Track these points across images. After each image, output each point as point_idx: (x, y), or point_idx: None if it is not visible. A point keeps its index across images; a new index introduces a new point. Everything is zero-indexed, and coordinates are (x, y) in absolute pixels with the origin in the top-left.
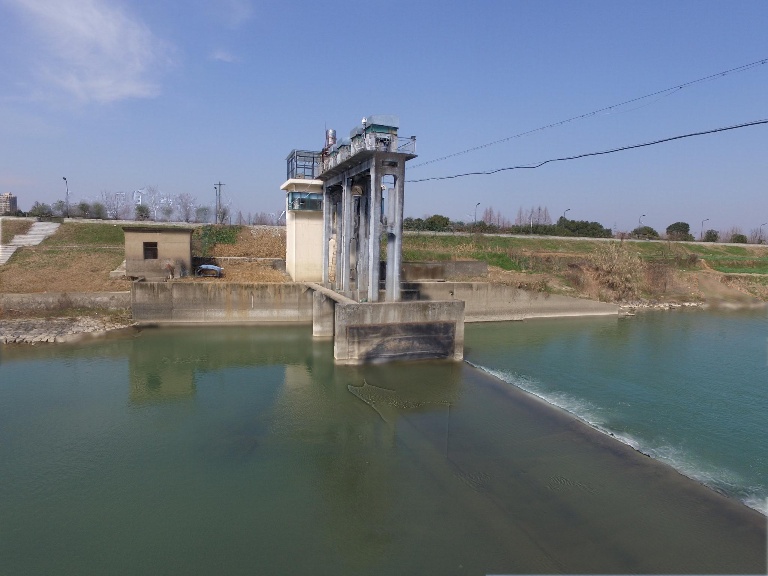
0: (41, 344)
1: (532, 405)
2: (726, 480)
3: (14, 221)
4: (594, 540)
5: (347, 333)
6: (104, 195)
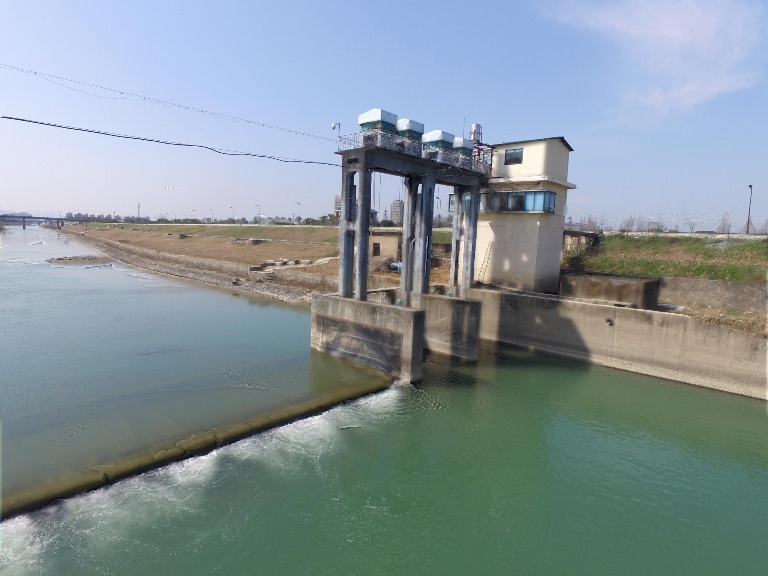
0: (279, 301)
1: None
2: None
3: (396, 230)
4: None
5: (317, 320)
6: None
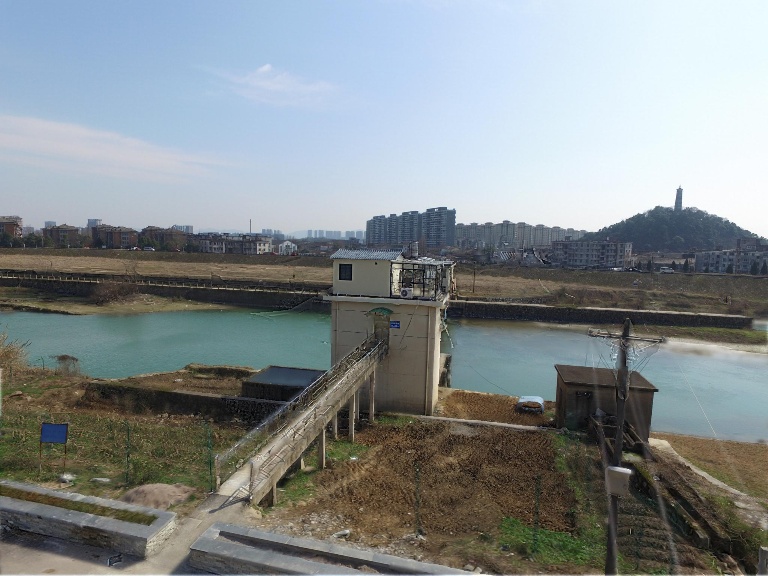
0: None
1: None
2: None
3: None
4: None
5: None
6: None
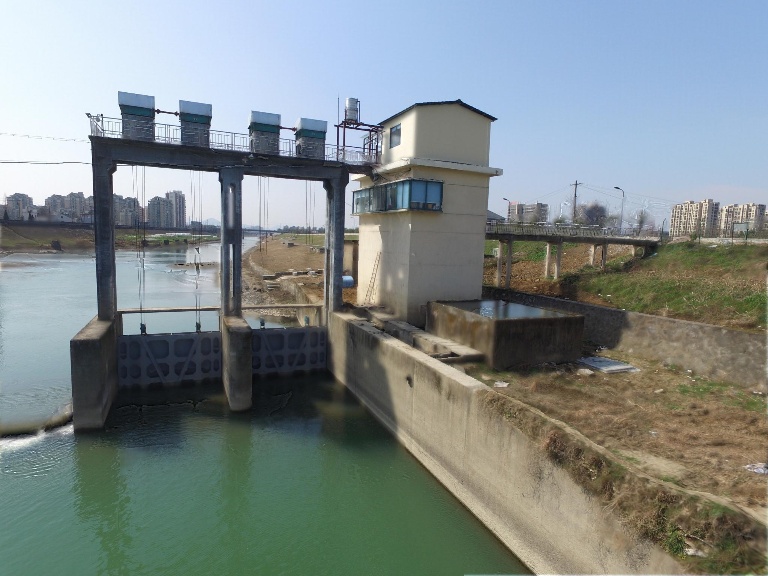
0: None
1: None
2: None
3: None
4: None
5: None
6: (535, 211)
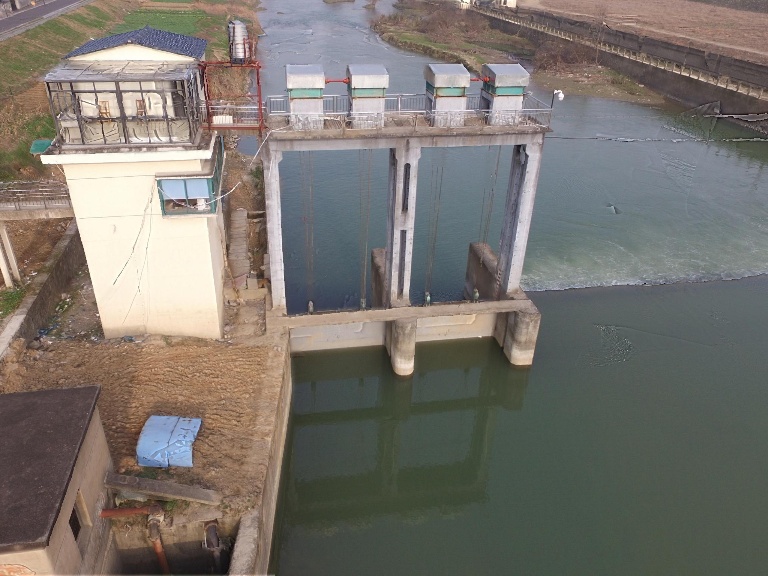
0: None
1: (608, 294)
2: (681, 275)
3: None
4: (767, 325)
5: None
6: None
